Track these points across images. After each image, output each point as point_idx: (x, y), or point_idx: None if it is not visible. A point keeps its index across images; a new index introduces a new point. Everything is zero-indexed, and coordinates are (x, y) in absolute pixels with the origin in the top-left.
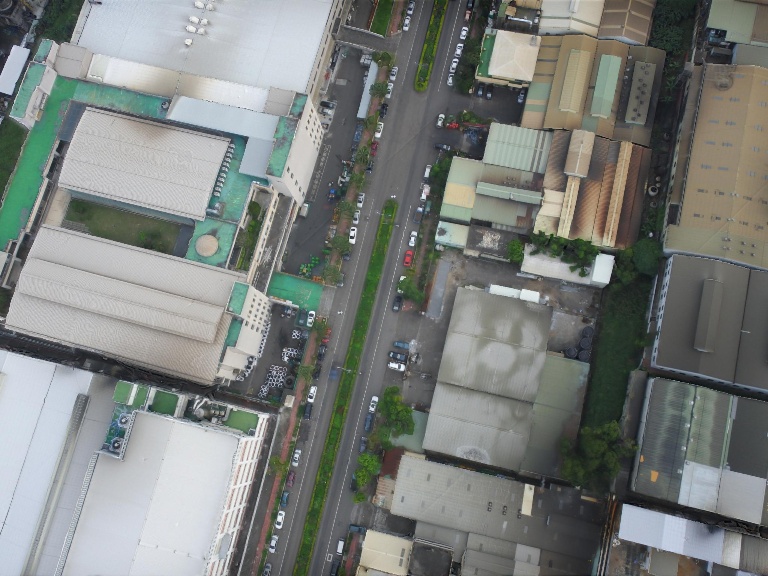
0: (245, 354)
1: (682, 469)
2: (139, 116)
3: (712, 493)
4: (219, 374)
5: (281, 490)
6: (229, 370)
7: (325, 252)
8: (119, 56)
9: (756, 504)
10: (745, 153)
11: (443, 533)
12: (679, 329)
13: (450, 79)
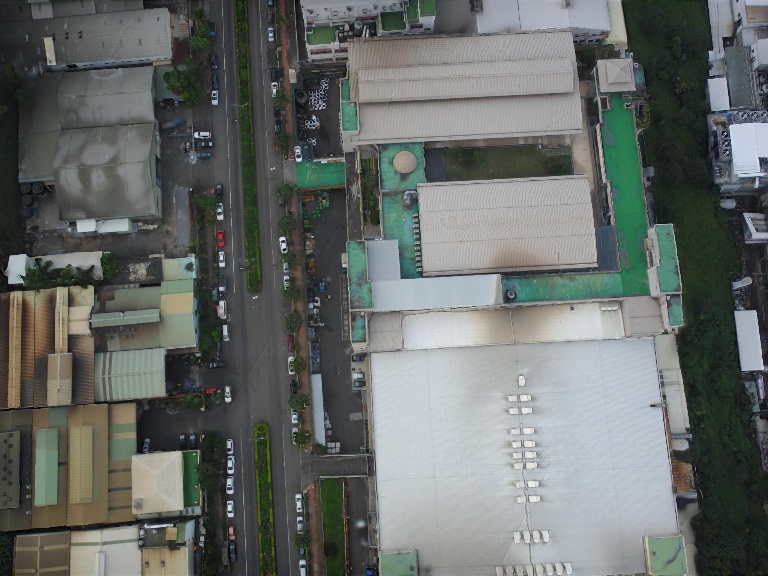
0: None
1: None
2: (535, 273)
3: None
4: None
5: (277, 7)
6: None
7: (310, 225)
8: (598, 346)
9: None
10: None
11: (119, 7)
12: None
13: (230, 445)
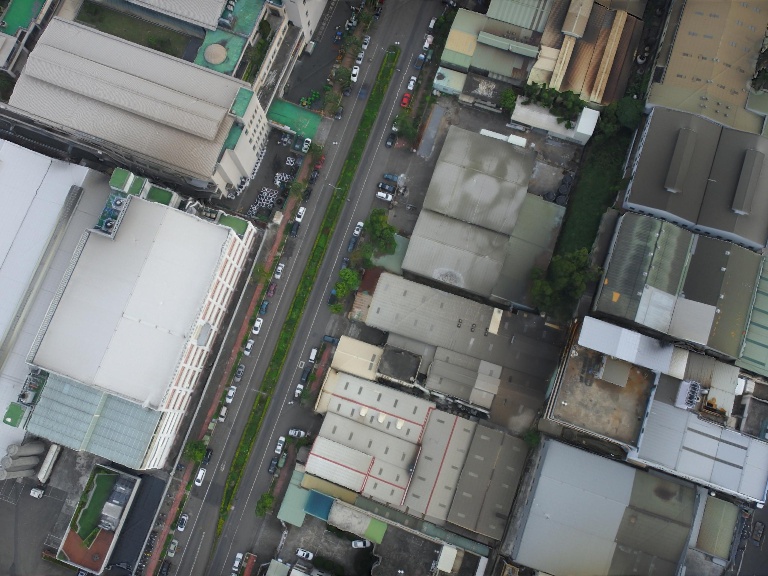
0: (240, 169)
1: (642, 292)
2: None
3: (666, 316)
4: (214, 178)
5: (261, 299)
6: (223, 179)
7: (326, 88)
8: None
9: (704, 328)
10: (729, 25)
11: (413, 346)
12: (653, 171)
13: None
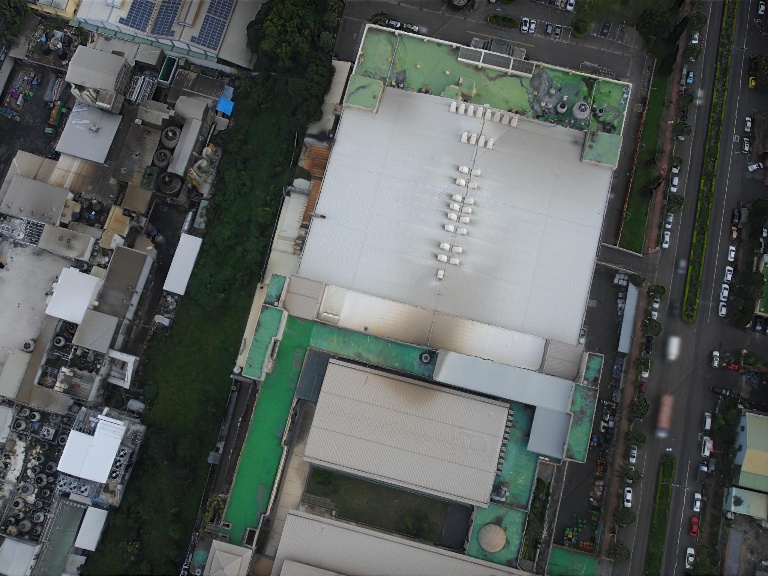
0: None
1: None
2: (395, 372)
3: None
4: None
5: None
6: None
7: (592, 513)
8: (354, 286)
9: None
10: None
11: None
12: None
13: (723, 310)
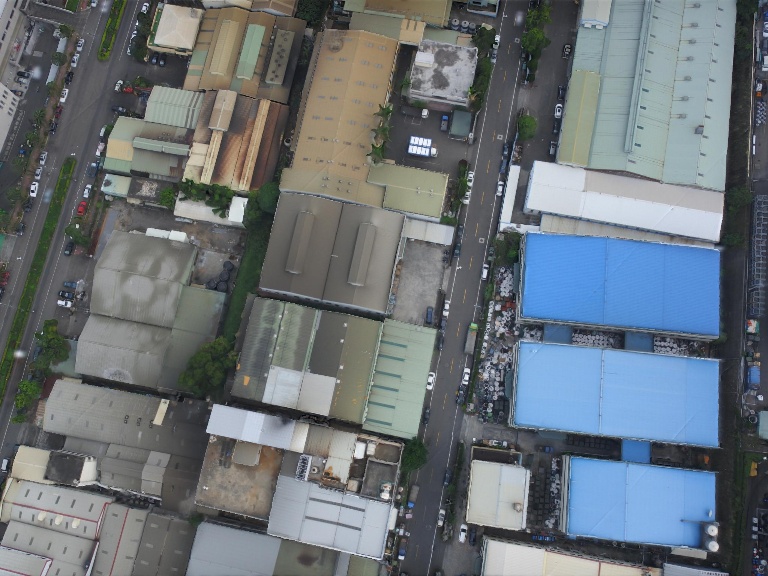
0: None
1: (268, 373)
2: None
3: (294, 392)
4: None
5: None
6: None
7: (12, 206)
8: None
9: (326, 399)
10: (347, 105)
11: (88, 445)
12: (277, 255)
13: (128, 49)
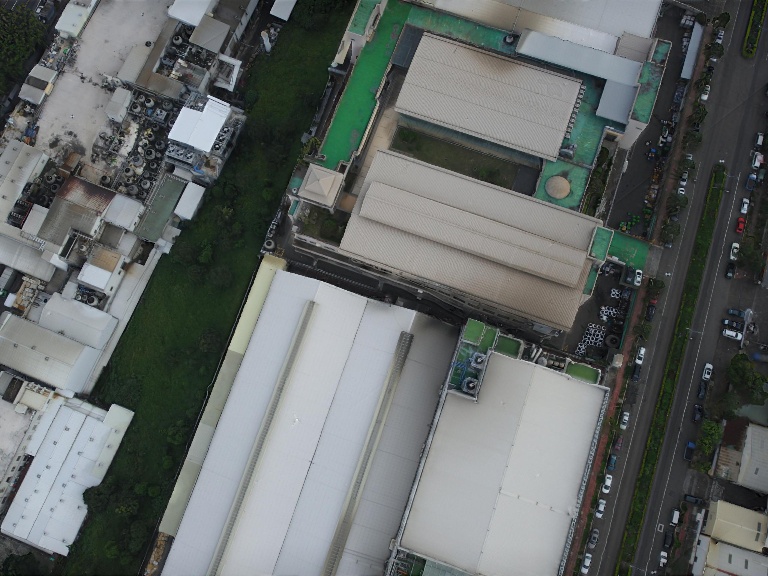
0: None
1: None
2: (481, 47)
3: None
4: None
5: (607, 453)
6: None
7: (646, 211)
8: None
9: None
10: None
11: None
12: None
13: None
